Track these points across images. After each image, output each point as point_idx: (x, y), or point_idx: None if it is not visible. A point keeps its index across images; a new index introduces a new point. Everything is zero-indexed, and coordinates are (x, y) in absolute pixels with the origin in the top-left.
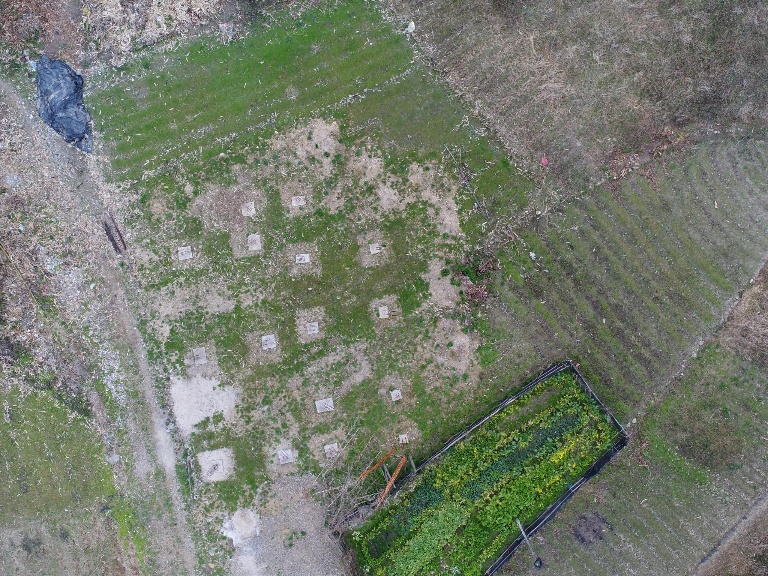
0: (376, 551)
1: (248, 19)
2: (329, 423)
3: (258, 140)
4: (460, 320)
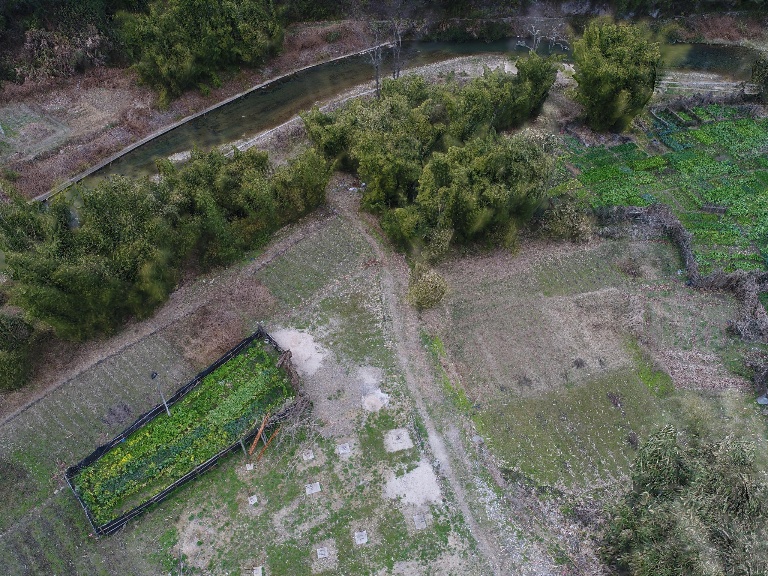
0: (277, 391)
1: None
2: (310, 475)
3: None
4: (188, 567)
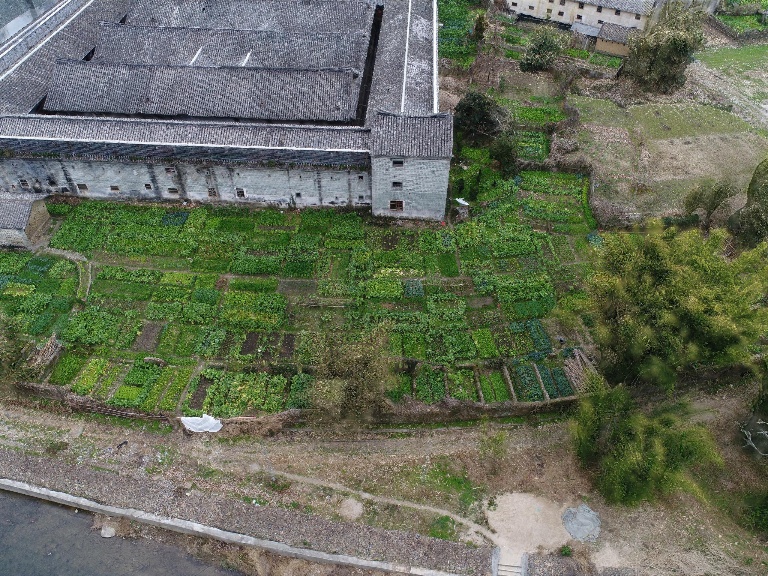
0: None
1: (740, 45)
2: None
3: (760, 63)
4: None
